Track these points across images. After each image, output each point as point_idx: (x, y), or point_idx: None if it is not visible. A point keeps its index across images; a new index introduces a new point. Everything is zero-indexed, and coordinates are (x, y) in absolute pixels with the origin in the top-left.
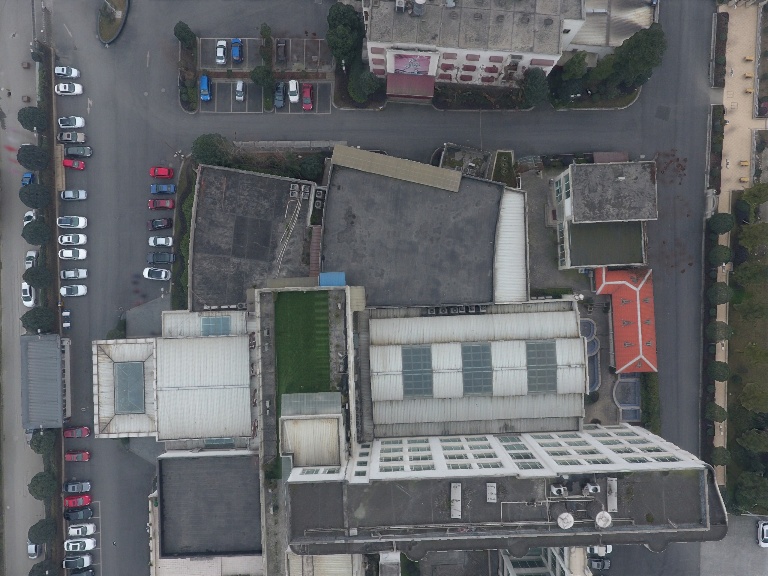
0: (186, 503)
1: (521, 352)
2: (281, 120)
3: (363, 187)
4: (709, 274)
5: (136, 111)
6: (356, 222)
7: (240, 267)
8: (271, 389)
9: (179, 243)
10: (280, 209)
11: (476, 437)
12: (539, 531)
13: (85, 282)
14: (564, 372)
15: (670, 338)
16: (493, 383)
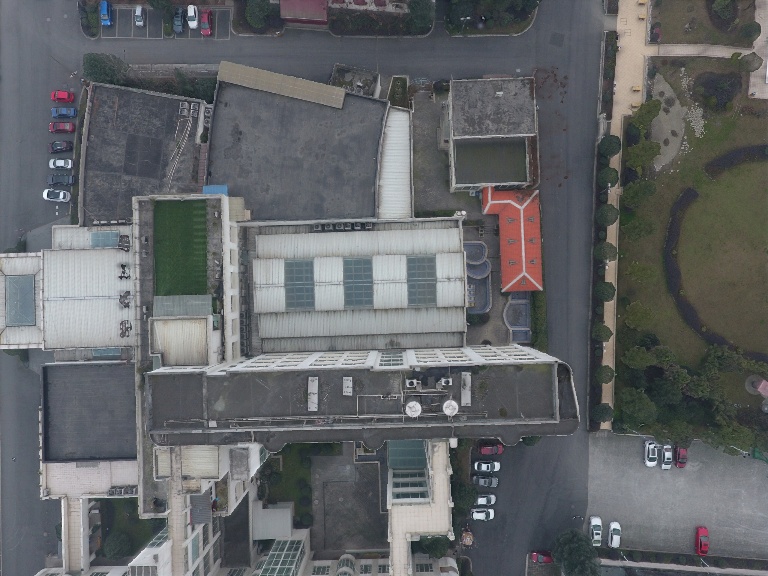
0: (71, 410)
1: (402, 266)
2: (181, 46)
3: (249, 104)
4: (599, 197)
5: (38, 36)
6: (242, 138)
7: (131, 184)
8: (149, 295)
9: (78, 165)
10: (171, 128)
11: (361, 352)
12: (393, 423)
13: None
14: (444, 285)
15: (561, 261)
16: (374, 296)
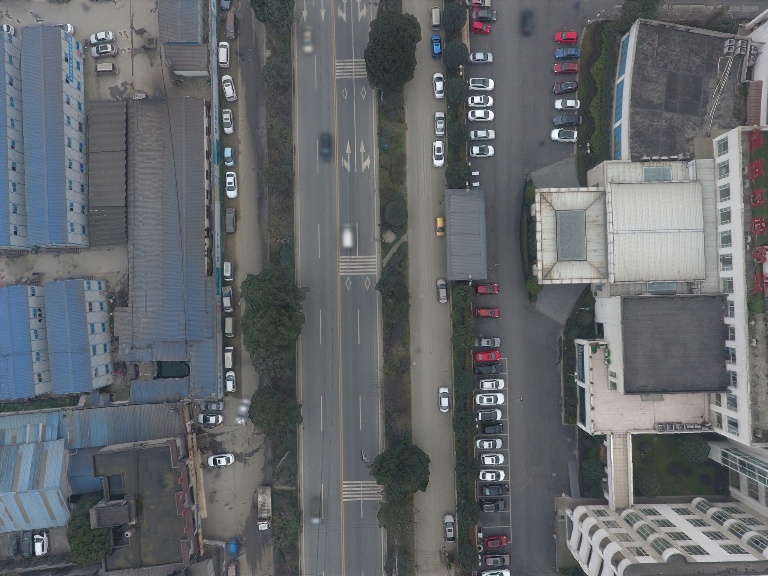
0: (642, 343)
1: None
2: None
3: None
4: None
5: None
6: None
7: (672, 121)
8: (747, 226)
9: (587, 106)
10: (711, 65)
11: None
12: None
13: (490, 144)
14: None
15: None
16: None
